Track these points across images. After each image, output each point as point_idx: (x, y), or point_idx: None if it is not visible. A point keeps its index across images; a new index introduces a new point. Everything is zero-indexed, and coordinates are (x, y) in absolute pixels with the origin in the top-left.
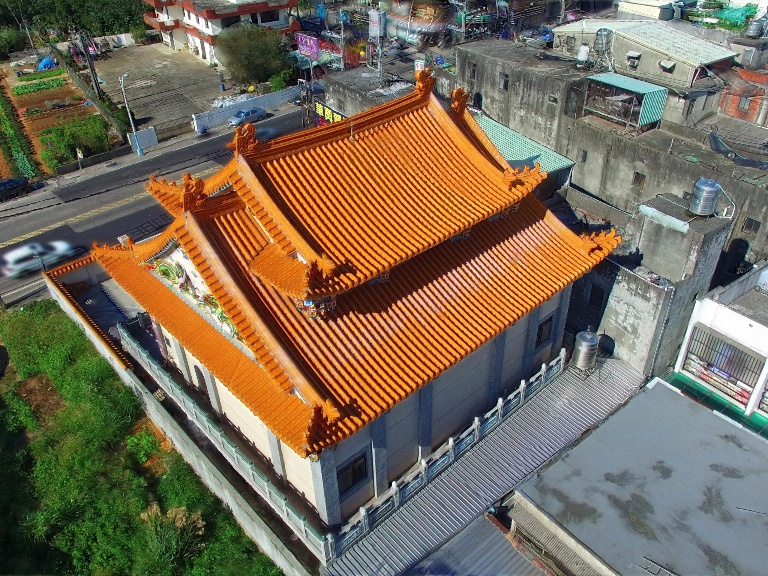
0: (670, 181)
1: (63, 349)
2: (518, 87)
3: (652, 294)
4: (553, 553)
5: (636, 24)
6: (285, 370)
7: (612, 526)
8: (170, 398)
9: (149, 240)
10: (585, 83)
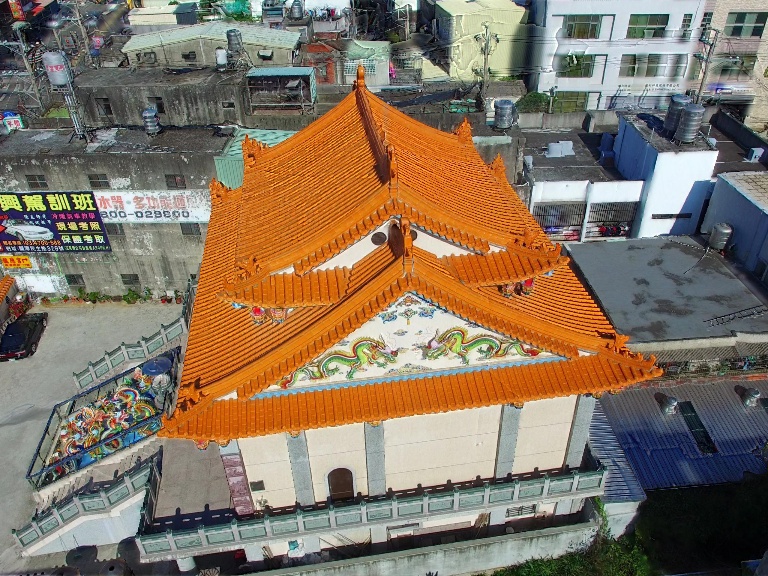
0: None
1: None
2: (179, 106)
3: (520, 193)
4: (672, 360)
5: (206, 27)
6: (564, 341)
7: (675, 321)
8: (249, 565)
9: None
10: (246, 82)
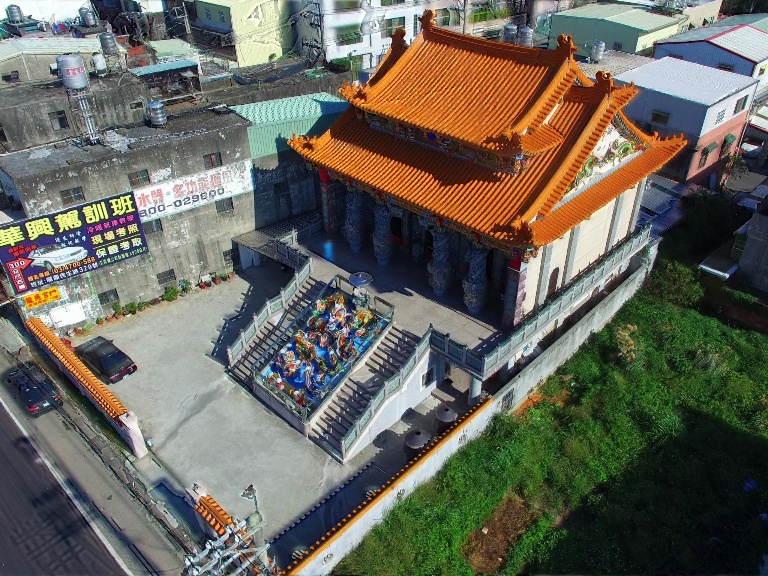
0: None
1: (438, 512)
2: None
3: None
4: None
5: (11, 44)
6: None
7: None
8: (513, 370)
9: (111, 535)
10: None
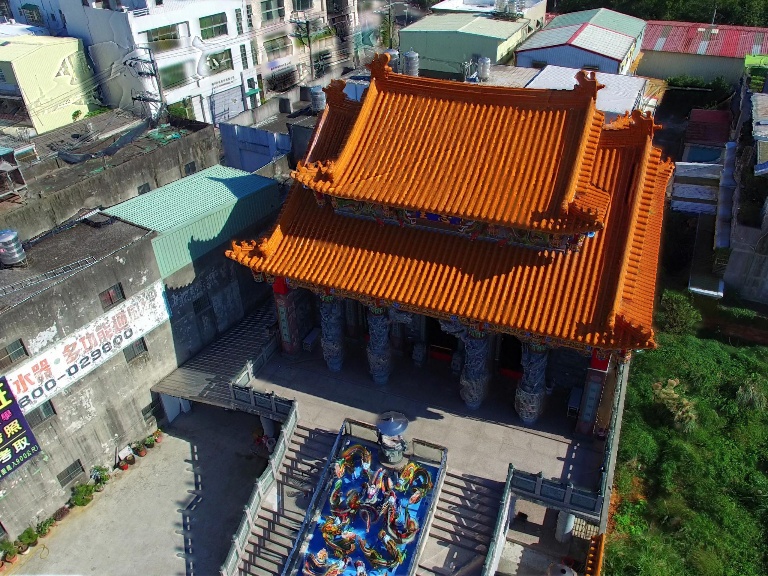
0: (124, 190)
1: None
2: None
3: None
4: None
5: None
6: None
7: None
8: None
9: None
10: None
